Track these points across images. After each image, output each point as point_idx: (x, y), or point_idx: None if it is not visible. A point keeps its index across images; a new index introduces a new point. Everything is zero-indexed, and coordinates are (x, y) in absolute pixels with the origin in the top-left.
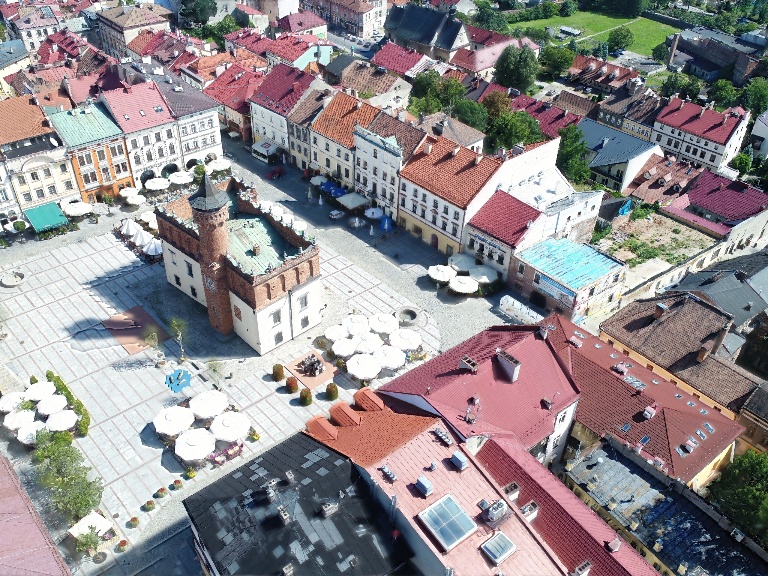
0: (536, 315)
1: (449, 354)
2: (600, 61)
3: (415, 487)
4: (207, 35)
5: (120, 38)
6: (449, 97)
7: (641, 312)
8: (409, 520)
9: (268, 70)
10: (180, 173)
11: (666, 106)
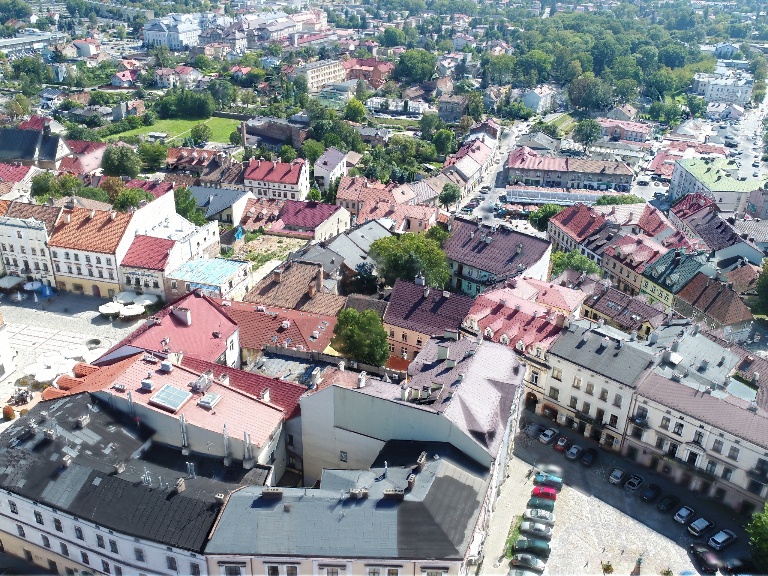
0: None
1: (137, 330)
2: (189, 149)
3: (142, 389)
4: None
5: None
6: (69, 191)
7: (266, 281)
8: (144, 405)
9: None
10: None
11: (248, 167)
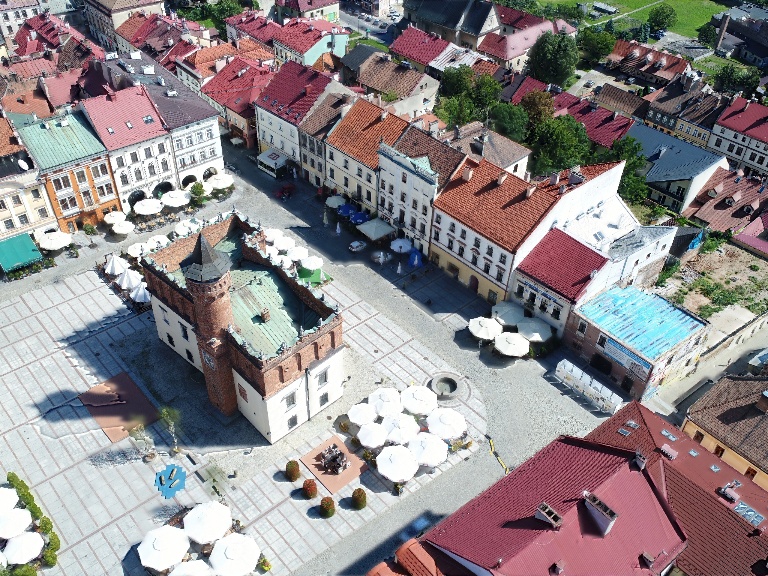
0: (601, 387)
1: (514, 480)
2: (644, 47)
3: None
4: (206, 16)
5: (108, 22)
6: (482, 97)
7: (739, 399)
8: None
9: (275, 61)
10: (174, 193)
11: (728, 106)
